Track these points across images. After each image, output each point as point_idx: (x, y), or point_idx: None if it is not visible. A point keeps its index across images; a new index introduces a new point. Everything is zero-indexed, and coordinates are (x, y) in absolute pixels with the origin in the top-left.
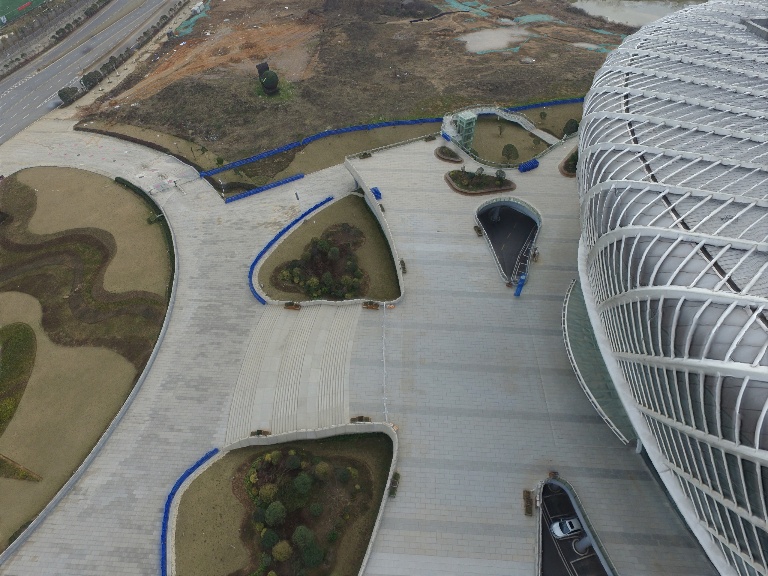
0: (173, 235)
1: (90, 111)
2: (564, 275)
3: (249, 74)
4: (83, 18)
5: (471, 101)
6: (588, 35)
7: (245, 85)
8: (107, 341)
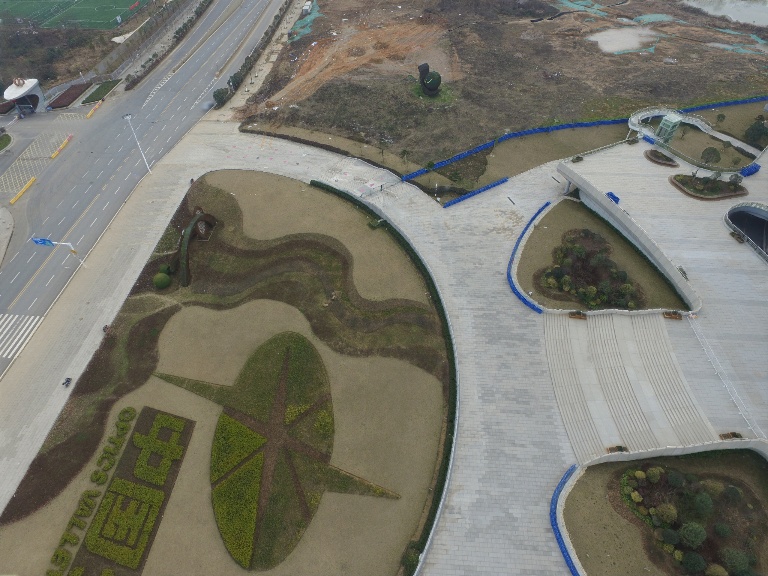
0: (410, 241)
1: (249, 113)
2: None
3: (397, 75)
4: (194, 18)
5: (636, 103)
6: (717, 35)
7: (401, 86)
8: (394, 351)
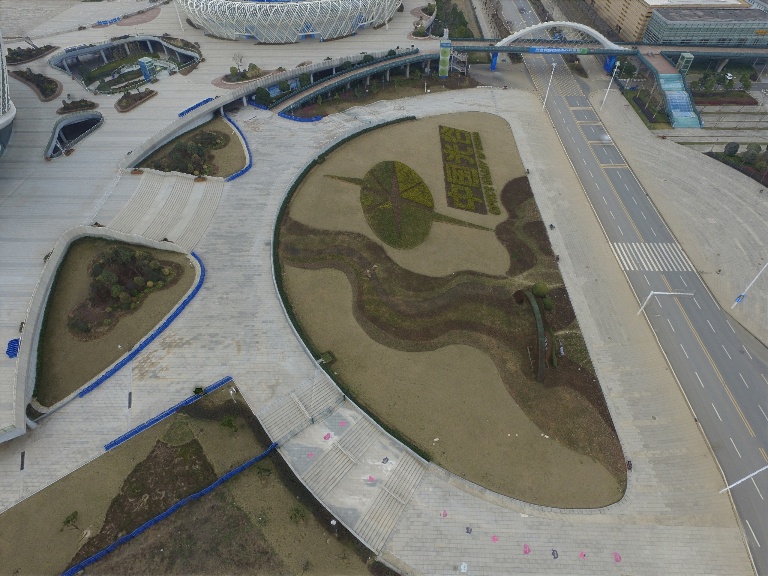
0: None
1: None
2: None
3: None
4: None
5: None
6: None
7: None
8: (319, 233)
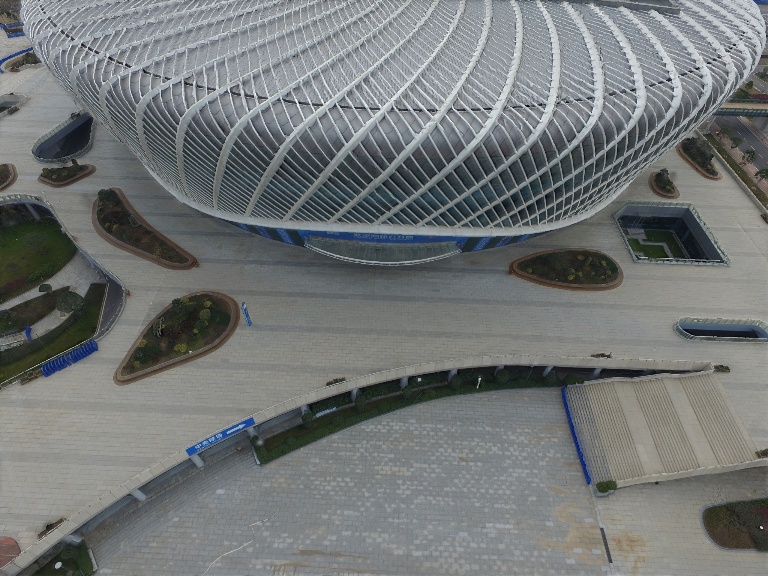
0: None
1: None
2: None
3: None
4: None
5: None
6: None
7: None
8: None
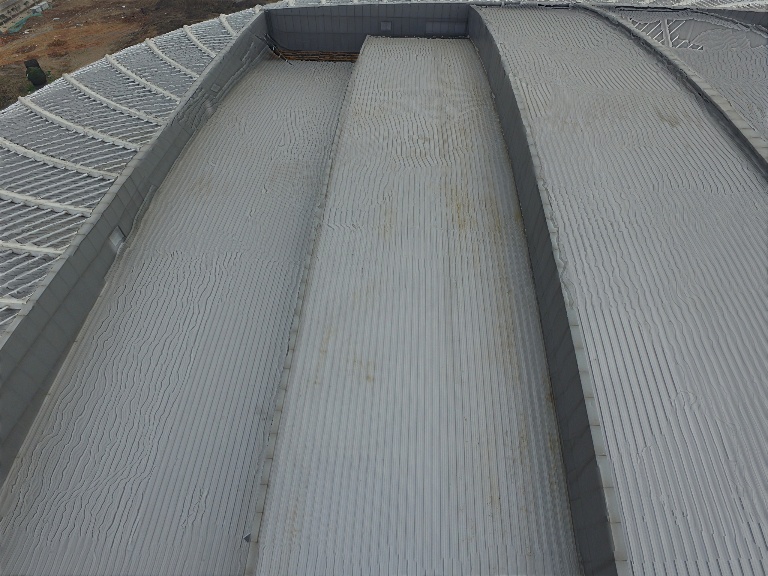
0: None
1: None
2: None
3: None
4: None
5: None
6: None
7: (21, 81)
8: None
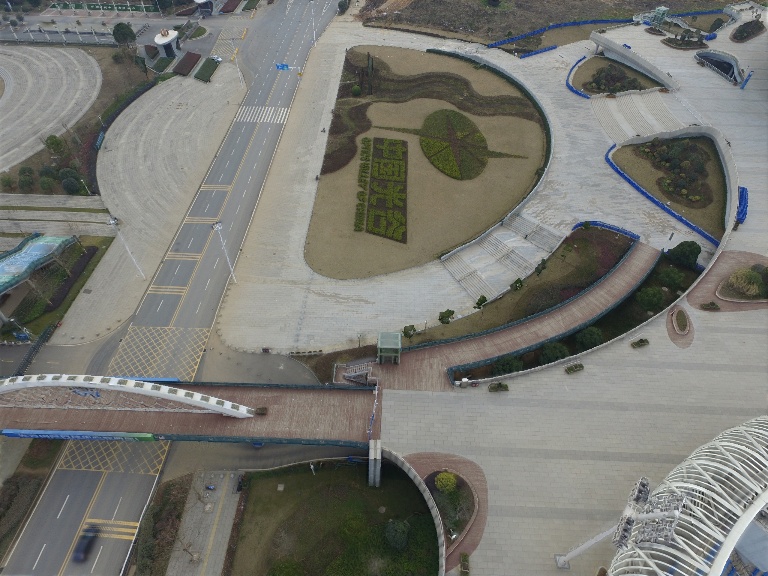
0: None
1: (366, 16)
2: (763, 82)
3: None
4: None
5: (637, 12)
6: None
7: (471, 0)
8: (509, 114)
